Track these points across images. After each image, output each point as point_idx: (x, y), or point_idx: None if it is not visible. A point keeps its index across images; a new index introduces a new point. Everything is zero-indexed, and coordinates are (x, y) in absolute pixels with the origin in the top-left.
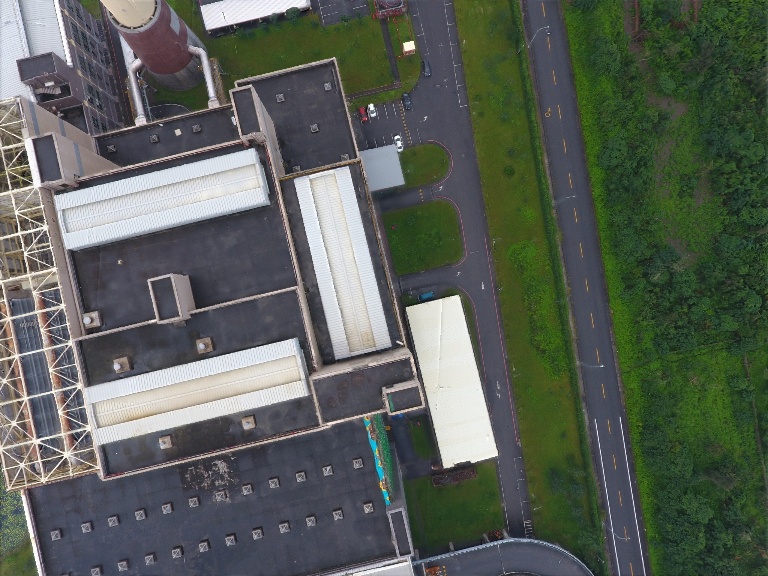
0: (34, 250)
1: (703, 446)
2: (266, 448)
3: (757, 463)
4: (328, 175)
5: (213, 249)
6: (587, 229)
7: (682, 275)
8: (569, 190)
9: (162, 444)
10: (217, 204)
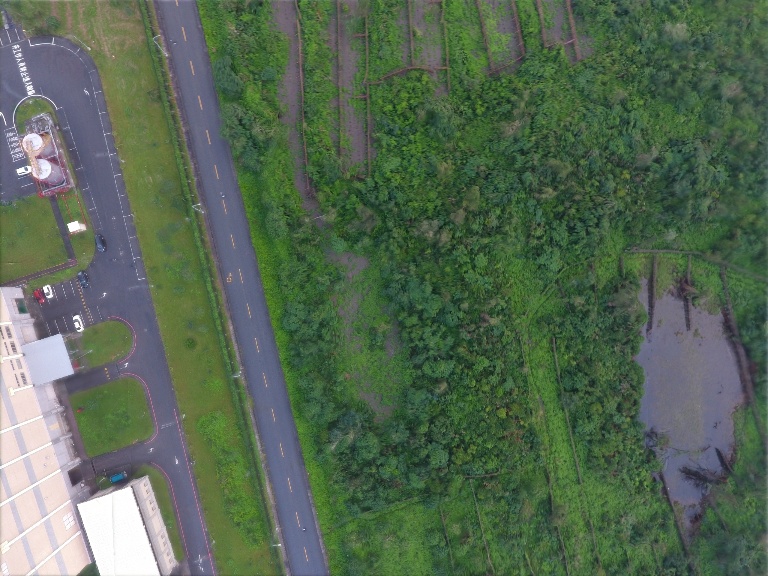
0: None
1: None
2: None
3: None
4: None
5: None
6: (278, 393)
7: (361, 441)
8: (256, 355)
9: None
10: None
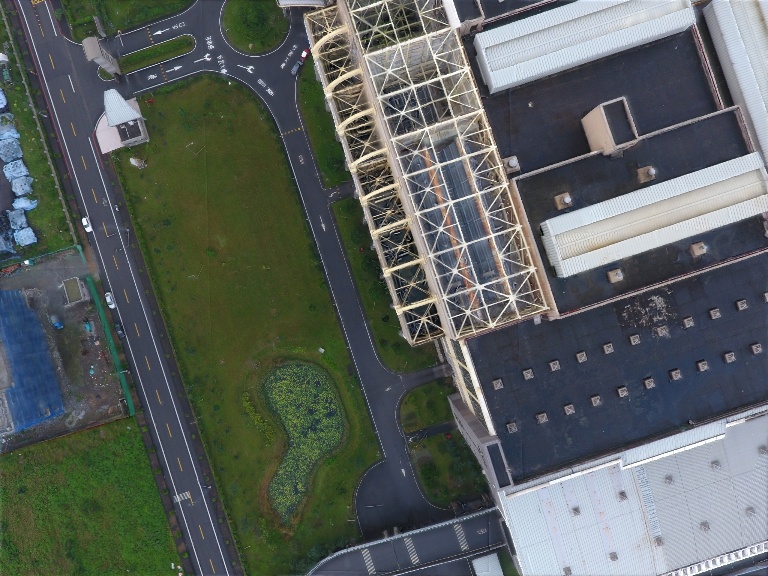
0: (456, 94)
1: None
2: (702, 279)
3: None
4: None
5: (625, 83)
6: None
7: None
8: None
9: (621, 274)
10: (646, 28)
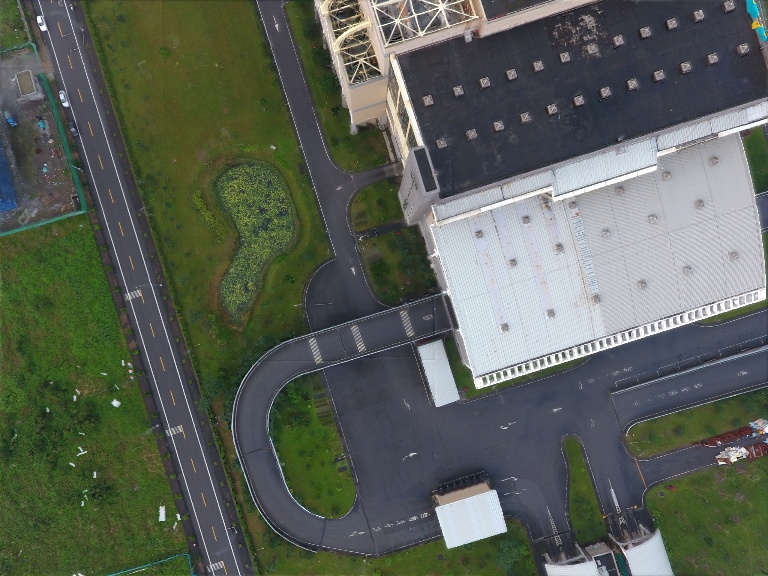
0: None
1: None
2: None
3: None
4: None
5: None
6: None
7: None
8: None
9: None
10: None
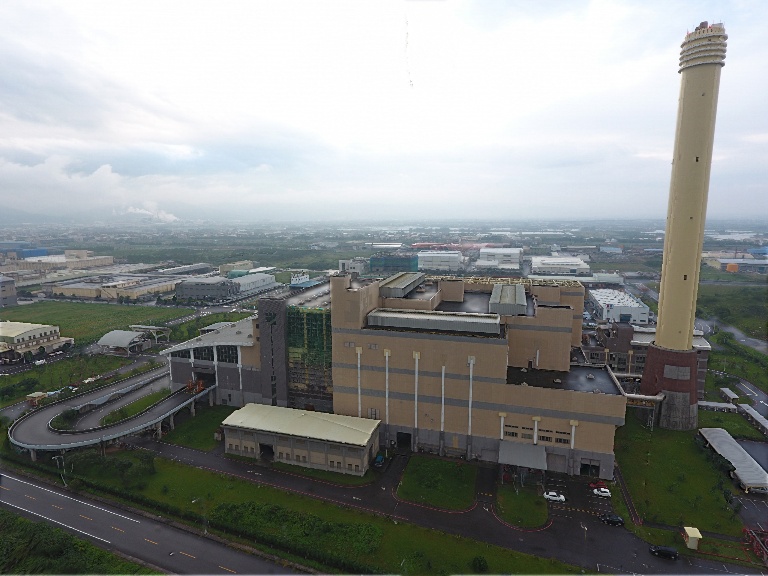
0: None
1: None
2: None
3: None
4: None
5: None
6: None
7: None
8: None
9: None
10: None
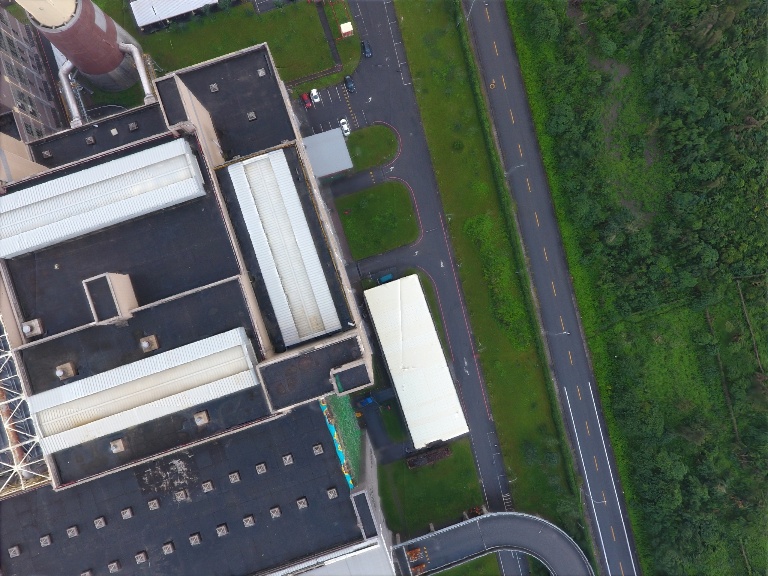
0: None
1: (673, 404)
2: (223, 443)
3: (727, 416)
4: (262, 160)
5: (152, 245)
6: (541, 198)
7: (637, 235)
8: (520, 160)
9: (113, 448)
10: (149, 198)
